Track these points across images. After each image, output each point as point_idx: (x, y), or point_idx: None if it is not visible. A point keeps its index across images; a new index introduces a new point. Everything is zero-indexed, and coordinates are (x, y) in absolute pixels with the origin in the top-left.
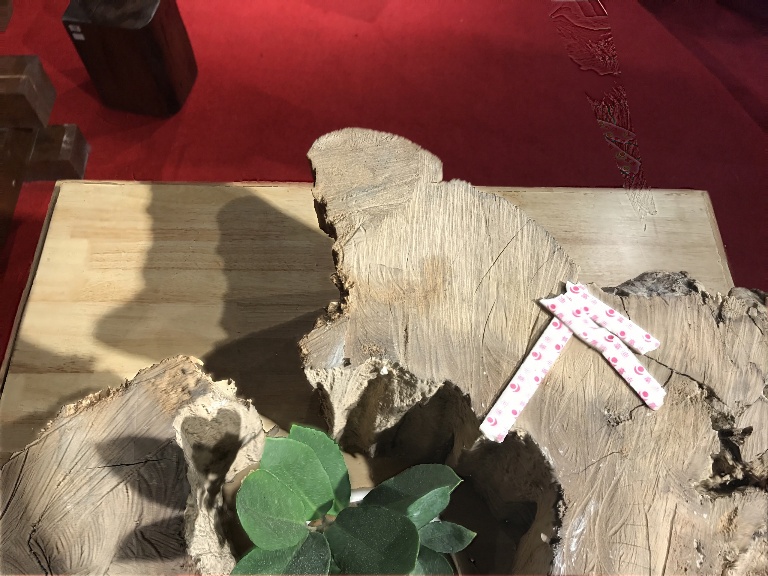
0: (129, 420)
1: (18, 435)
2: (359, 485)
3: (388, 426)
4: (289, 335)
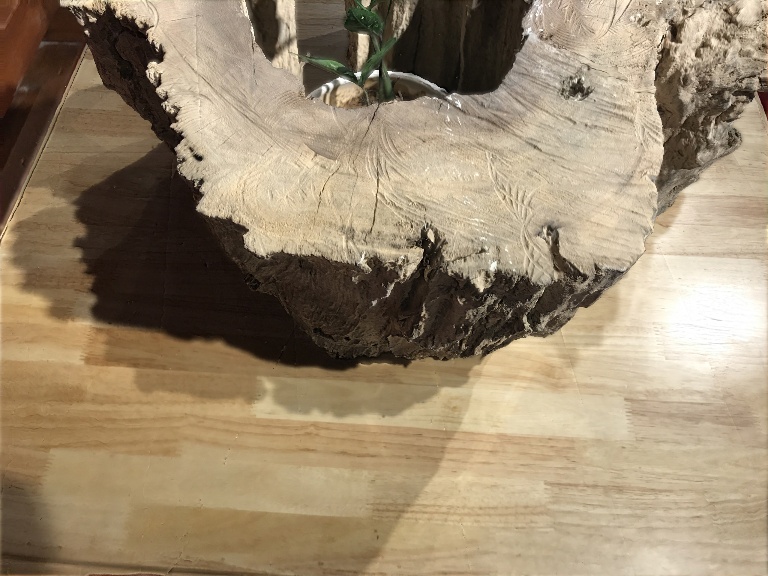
0: None
1: (88, 98)
2: None
3: (404, 26)
4: (324, 44)
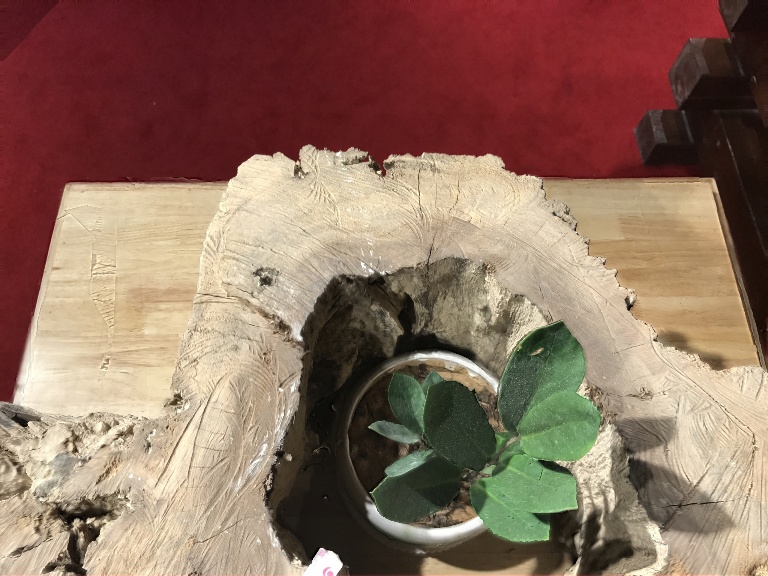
0: (713, 553)
1: None
2: (436, 572)
3: None
4: None
